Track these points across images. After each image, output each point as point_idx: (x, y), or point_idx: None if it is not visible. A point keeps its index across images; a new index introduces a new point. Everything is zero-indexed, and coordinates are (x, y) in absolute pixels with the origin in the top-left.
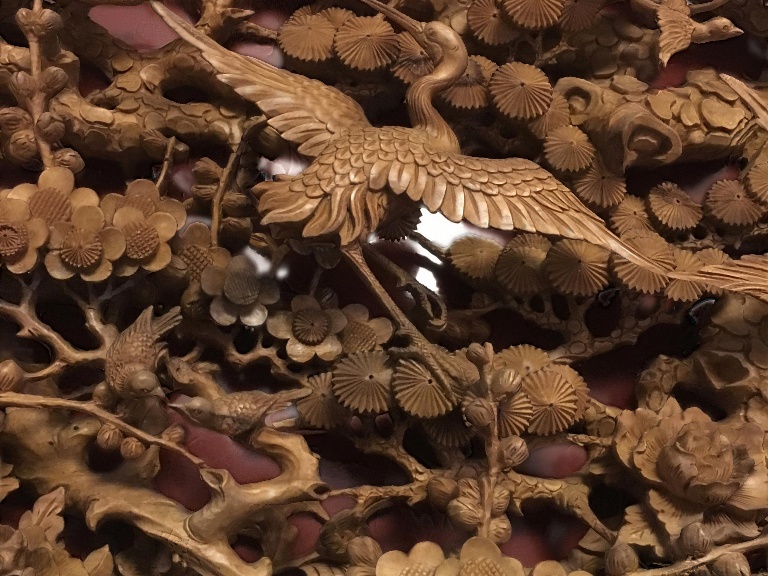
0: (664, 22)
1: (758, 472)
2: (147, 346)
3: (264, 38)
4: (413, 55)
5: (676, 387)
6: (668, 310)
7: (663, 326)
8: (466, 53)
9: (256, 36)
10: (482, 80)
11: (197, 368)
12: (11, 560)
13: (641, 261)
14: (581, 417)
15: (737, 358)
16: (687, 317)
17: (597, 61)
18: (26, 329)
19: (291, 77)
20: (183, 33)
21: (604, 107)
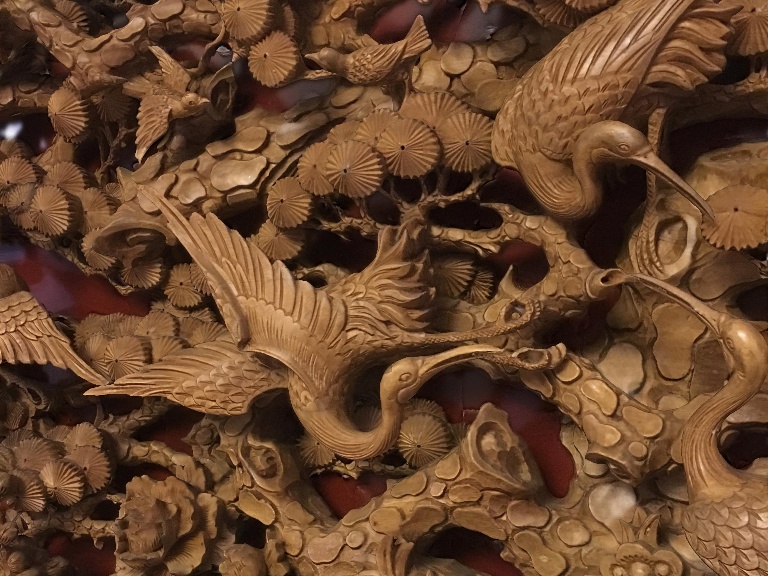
0: (142, 114)
1: (199, 535)
2: None
3: None
4: (4, 185)
5: None
6: None
7: None
8: None
9: None
10: None
11: None
12: None
13: (86, 375)
14: (102, 486)
15: None
16: None
17: None
18: None
19: None
20: None
21: None
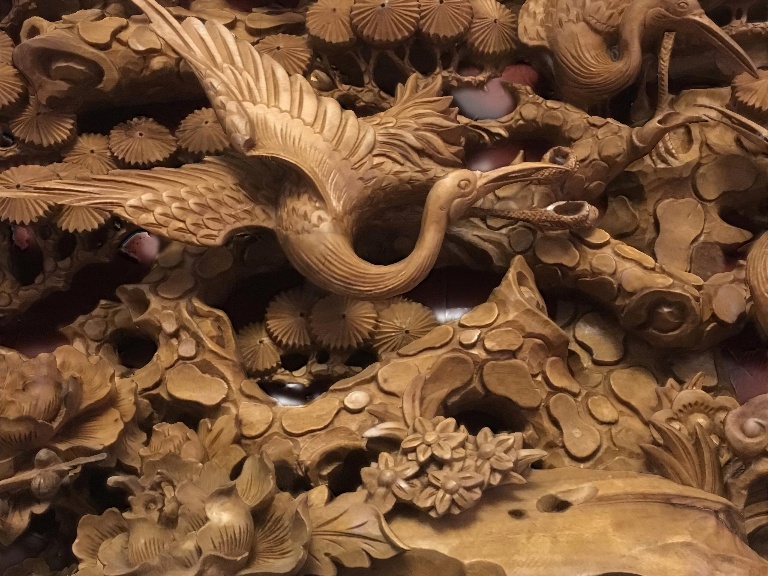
0: None
1: (112, 410)
2: None
3: None
4: None
5: (115, 334)
6: (88, 247)
7: (95, 267)
8: None
9: None
10: None
11: None
12: None
13: None
14: None
15: (142, 290)
16: (119, 254)
17: (93, 3)
18: None
19: None
20: None
21: None
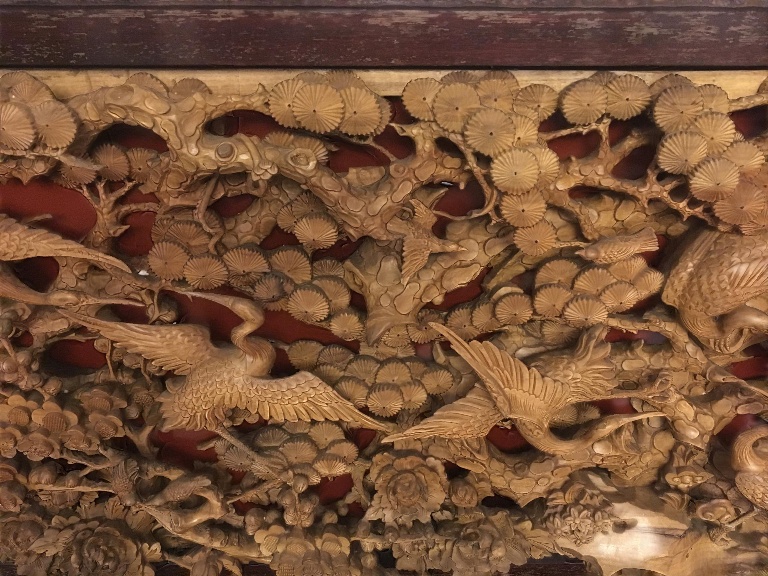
0: (407, 253)
1: None
2: (127, 483)
3: (146, 211)
4: (239, 272)
5: (420, 414)
6: None
7: None
8: (261, 318)
9: (140, 212)
10: (284, 295)
11: (156, 470)
12: (102, 563)
13: (373, 425)
14: None
15: None
16: None
17: None
18: (71, 462)
19: (158, 334)
20: (83, 323)
21: (370, 297)
